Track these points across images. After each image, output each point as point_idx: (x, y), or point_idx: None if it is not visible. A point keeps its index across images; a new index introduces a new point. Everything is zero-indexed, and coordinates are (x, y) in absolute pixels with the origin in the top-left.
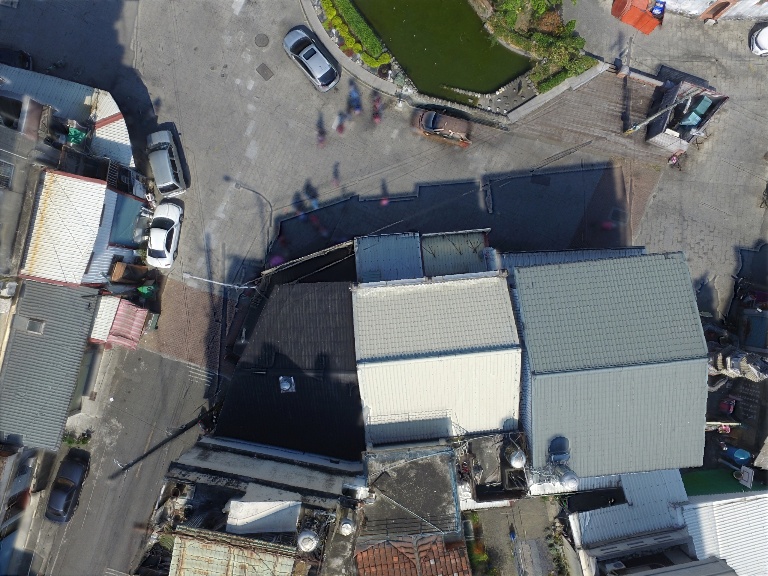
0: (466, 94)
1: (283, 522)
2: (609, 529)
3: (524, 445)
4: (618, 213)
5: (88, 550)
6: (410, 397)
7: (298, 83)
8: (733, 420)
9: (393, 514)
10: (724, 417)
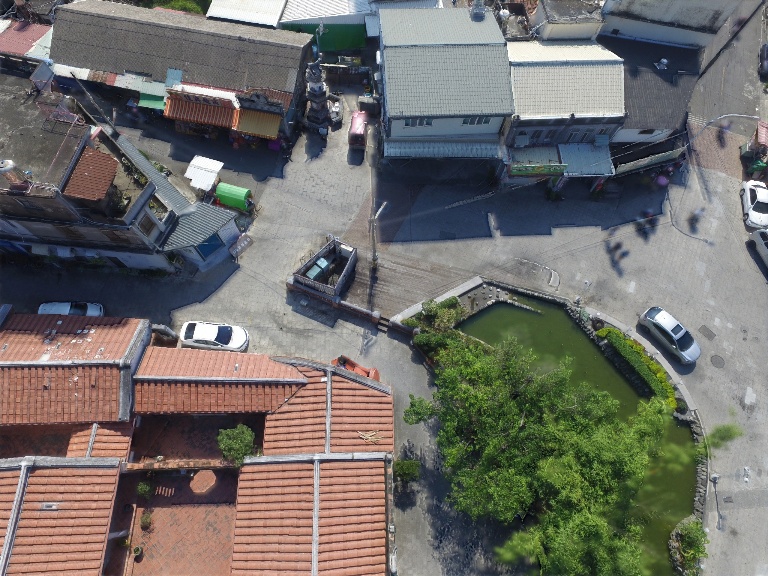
0: (520, 304)
1: None
2: (419, 5)
3: None
4: None
5: (743, 34)
6: None
7: None
8: None
9: None
10: None
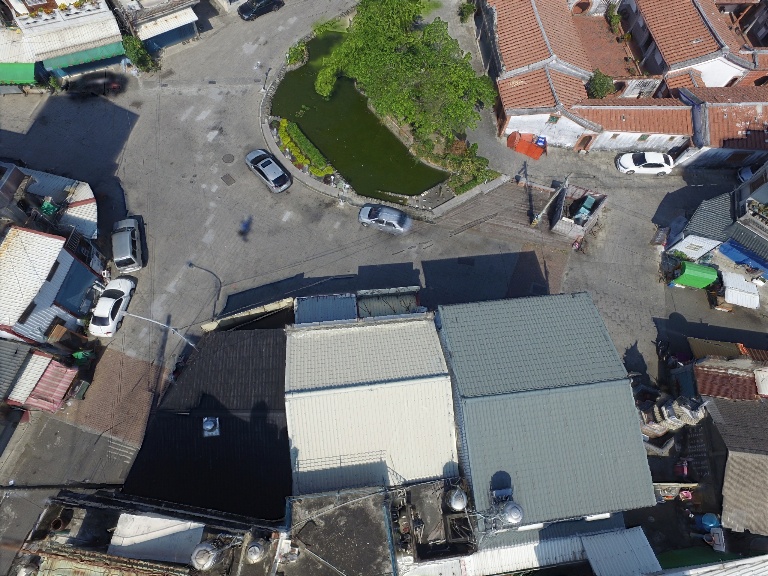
0: (397, 196)
1: (179, 549)
2: None
3: (465, 488)
4: (538, 287)
5: None
6: (341, 435)
7: (256, 188)
8: (690, 482)
9: (319, 575)
10: (681, 481)
